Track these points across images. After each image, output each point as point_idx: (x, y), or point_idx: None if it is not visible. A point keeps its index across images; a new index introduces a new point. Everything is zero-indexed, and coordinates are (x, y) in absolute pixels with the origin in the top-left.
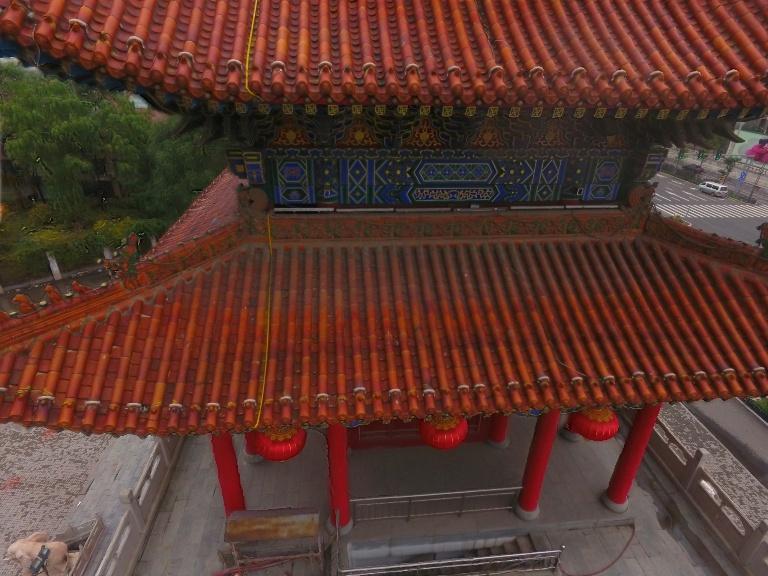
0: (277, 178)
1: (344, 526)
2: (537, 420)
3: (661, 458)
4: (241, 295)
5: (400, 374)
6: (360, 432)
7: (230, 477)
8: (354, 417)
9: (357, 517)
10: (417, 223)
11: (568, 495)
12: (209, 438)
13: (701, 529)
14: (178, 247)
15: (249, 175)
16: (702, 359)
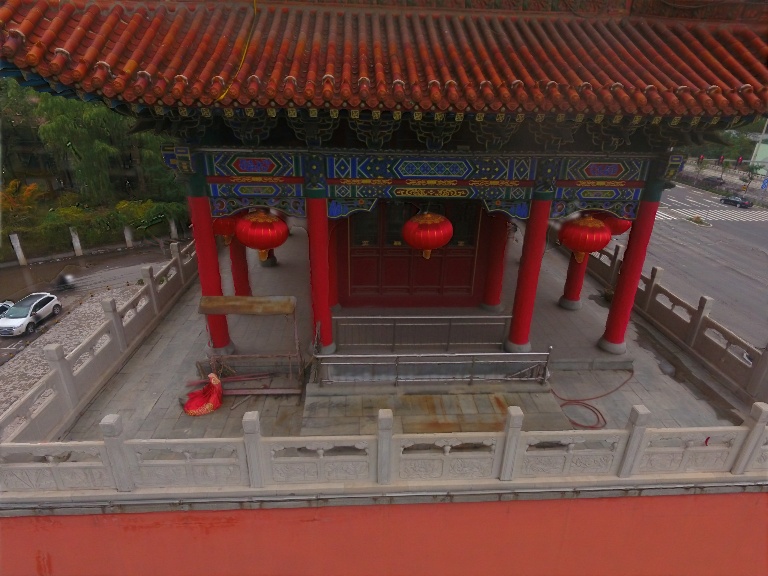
0: None
1: (326, 346)
2: (525, 229)
3: (665, 326)
4: (221, 32)
5: (372, 80)
6: (350, 285)
7: (210, 269)
8: (321, 97)
9: (340, 342)
10: None
11: (563, 342)
12: None
13: (706, 376)
14: None
15: None
16: (686, 84)
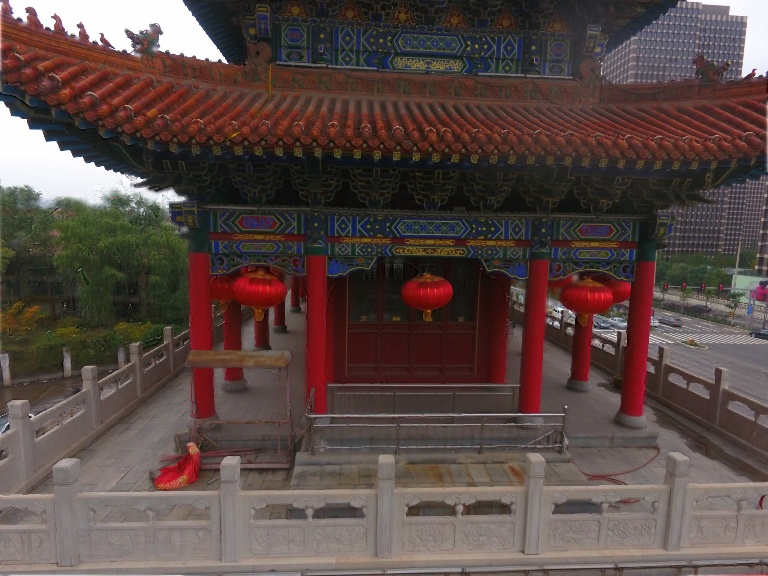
0: (281, 41)
1: None
2: (525, 290)
3: (684, 408)
4: None
5: (373, 131)
6: (347, 364)
7: (202, 328)
8: (326, 138)
9: None
10: (397, 80)
11: (577, 418)
12: (188, 387)
13: (740, 453)
14: (191, 58)
15: (258, 25)
16: None
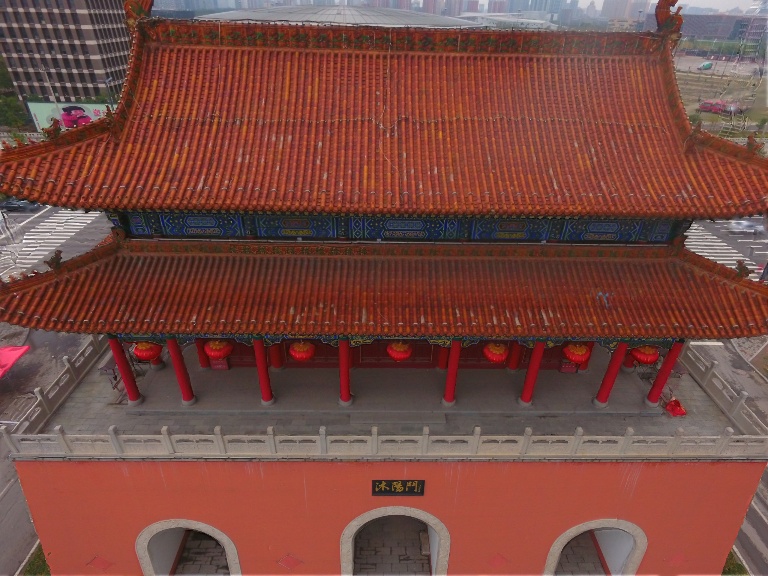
0: None
1: None
2: None
3: None
4: None
5: None
6: None
7: None
8: None
9: None
10: None
11: None
12: None
13: None
14: None
15: None
16: None
